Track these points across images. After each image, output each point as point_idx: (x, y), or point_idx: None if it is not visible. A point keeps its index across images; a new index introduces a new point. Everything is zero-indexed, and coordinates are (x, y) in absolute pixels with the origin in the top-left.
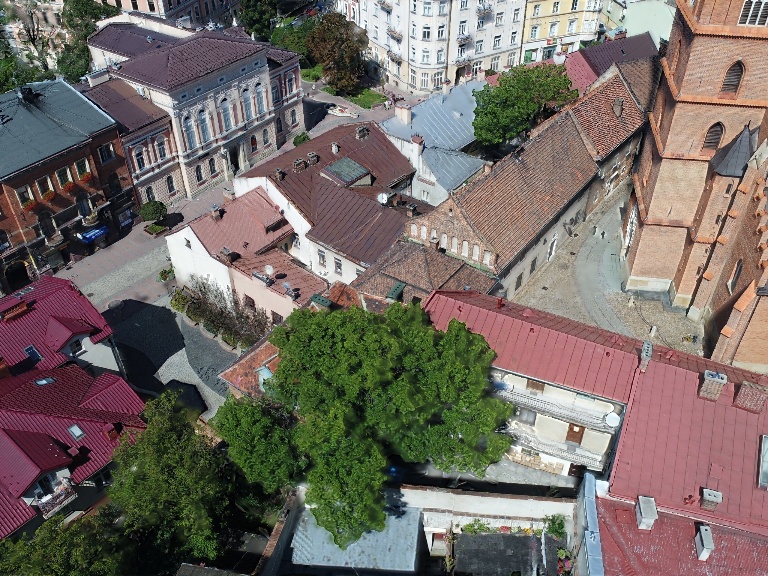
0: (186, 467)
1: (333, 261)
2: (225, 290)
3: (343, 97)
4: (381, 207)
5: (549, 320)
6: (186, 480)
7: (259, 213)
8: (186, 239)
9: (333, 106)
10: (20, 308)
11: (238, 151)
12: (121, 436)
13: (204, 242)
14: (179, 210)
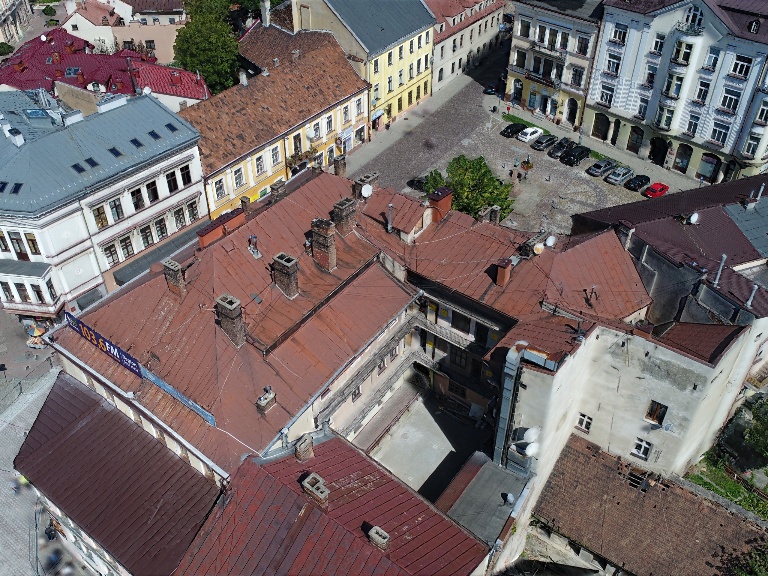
0: (219, 3)
1: (153, 22)
2: (109, 46)
3: (31, 3)
4: None
5: None
6: (222, 7)
7: (102, 6)
8: (73, 25)
9: (33, 5)
10: (49, 36)
11: (15, 21)
12: (149, 60)
13: (89, 19)
14: (8, 56)
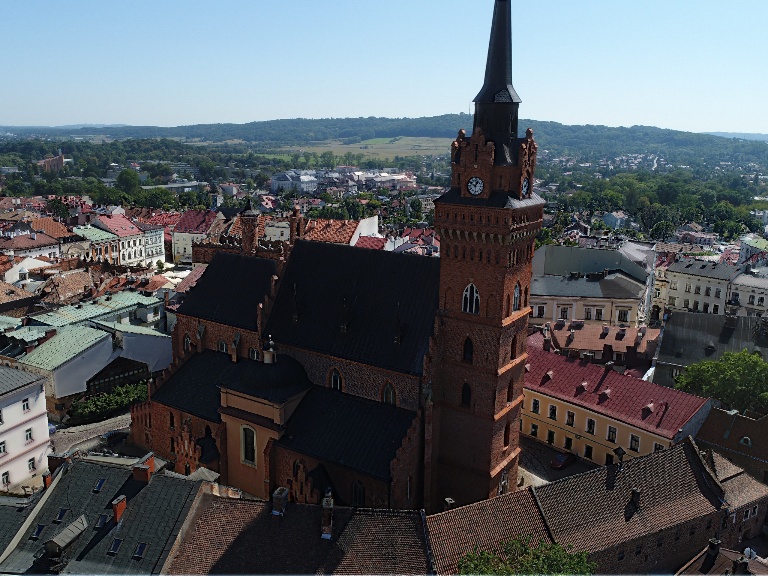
0: None
1: None
2: None
3: None
4: (751, 571)
5: (636, 409)
6: None
7: None
8: None
9: None
10: None
11: None
12: None
13: None
14: None
